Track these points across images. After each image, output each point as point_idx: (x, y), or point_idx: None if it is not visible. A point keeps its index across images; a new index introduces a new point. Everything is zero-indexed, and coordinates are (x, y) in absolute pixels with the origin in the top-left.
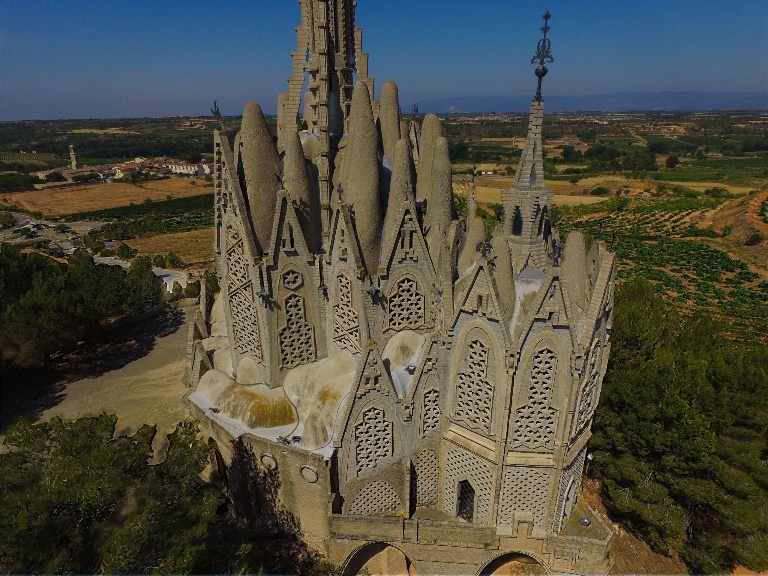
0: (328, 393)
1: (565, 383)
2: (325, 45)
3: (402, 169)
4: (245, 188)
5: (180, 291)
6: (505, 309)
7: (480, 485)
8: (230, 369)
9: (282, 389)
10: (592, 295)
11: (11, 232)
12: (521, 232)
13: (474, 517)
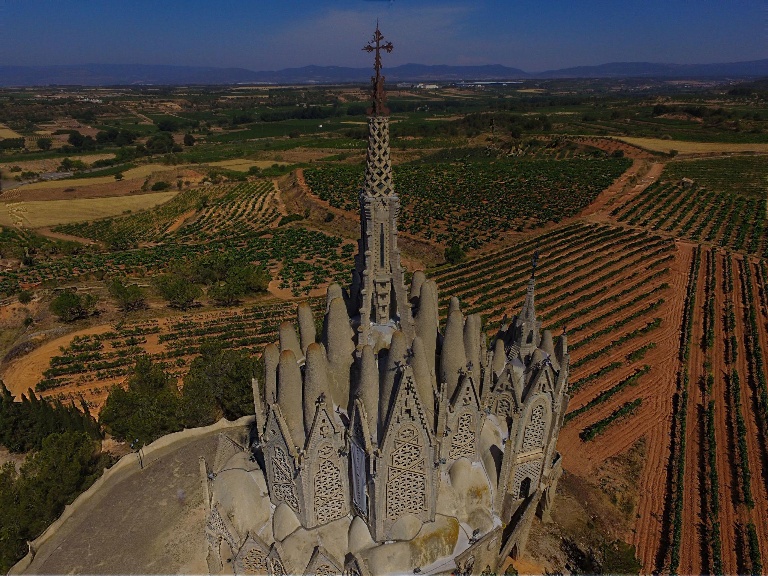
0: (479, 490)
1: (561, 400)
2: None
3: (475, 333)
4: None
5: None
6: None
7: (533, 474)
8: (366, 543)
9: (439, 515)
10: None
11: None
12: (532, 341)
13: (529, 492)
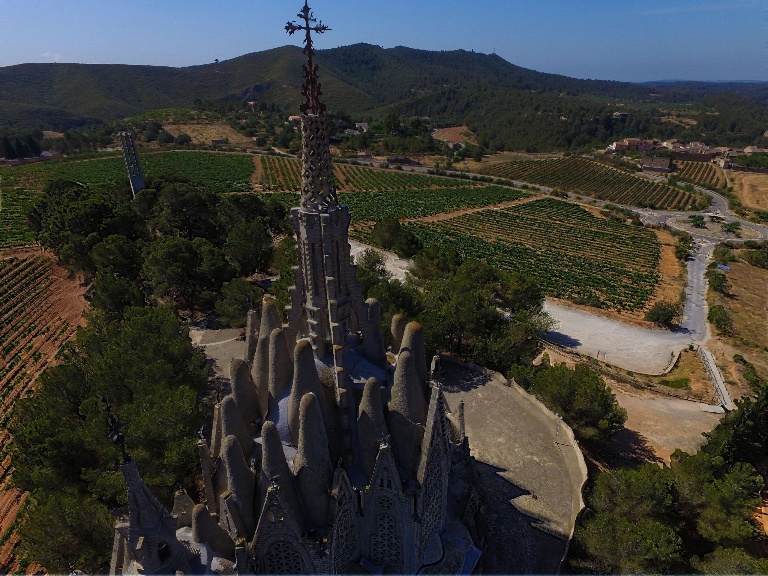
0: None
1: None
2: None
3: None
4: None
5: (547, 363)
6: None
7: None
8: None
9: None
10: None
11: (688, 216)
12: None
13: None
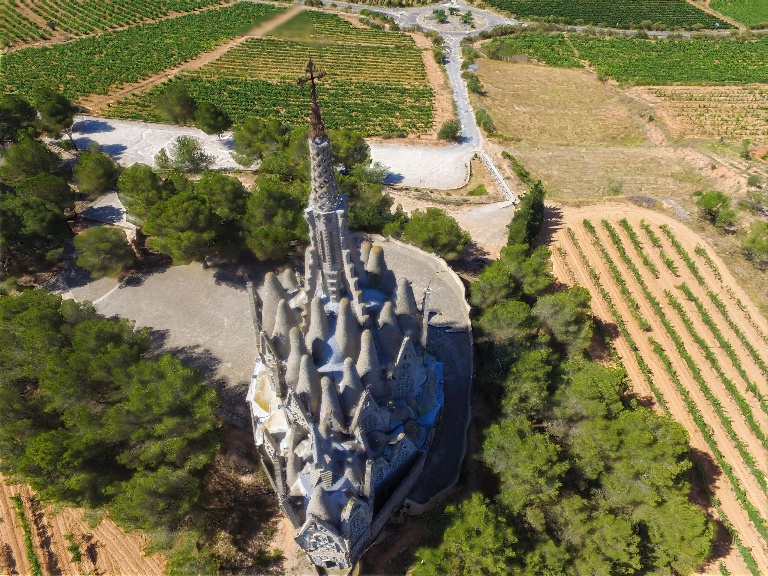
0: (270, 421)
1: None
2: (312, 261)
3: (302, 370)
4: (262, 310)
5: (401, 211)
6: (287, 481)
7: None
8: None
9: None
10: (306, 520)
11: None
12: None
13: None
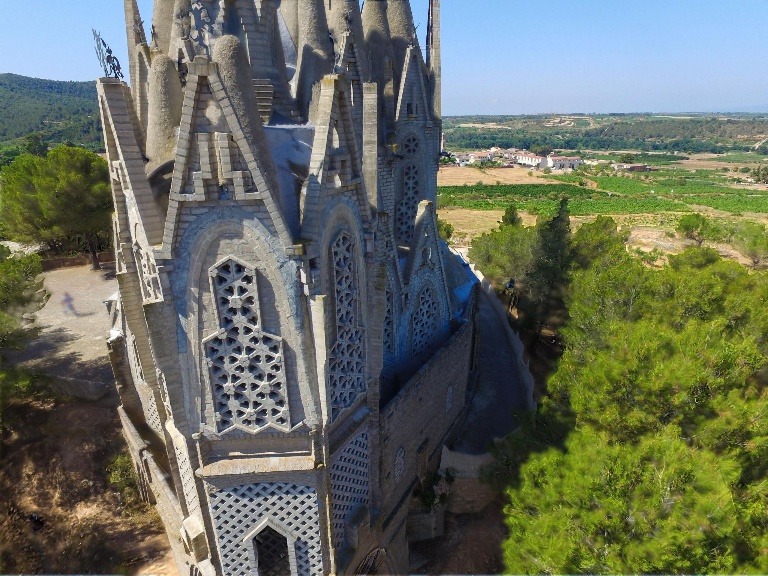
0: None
1: None
2: None
3: None
4: None
5: None
6: None
7: None
8: None
9: None
10: None
11: None
12: None
13: None
